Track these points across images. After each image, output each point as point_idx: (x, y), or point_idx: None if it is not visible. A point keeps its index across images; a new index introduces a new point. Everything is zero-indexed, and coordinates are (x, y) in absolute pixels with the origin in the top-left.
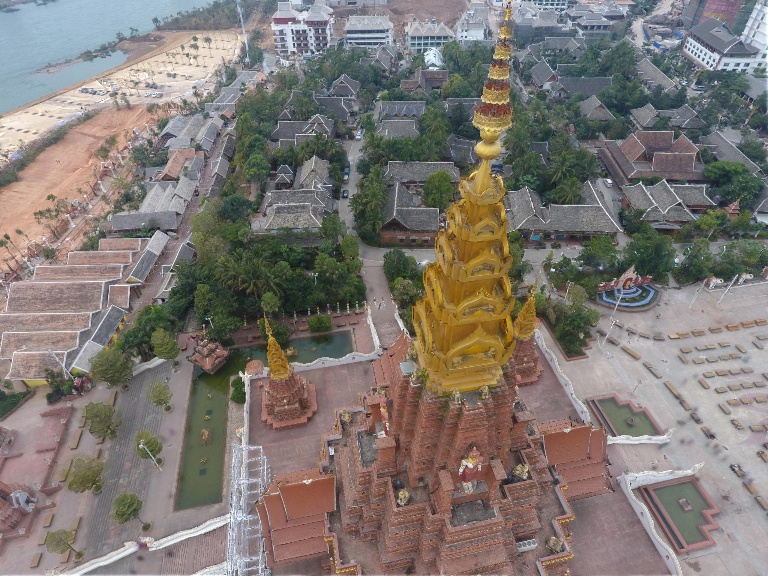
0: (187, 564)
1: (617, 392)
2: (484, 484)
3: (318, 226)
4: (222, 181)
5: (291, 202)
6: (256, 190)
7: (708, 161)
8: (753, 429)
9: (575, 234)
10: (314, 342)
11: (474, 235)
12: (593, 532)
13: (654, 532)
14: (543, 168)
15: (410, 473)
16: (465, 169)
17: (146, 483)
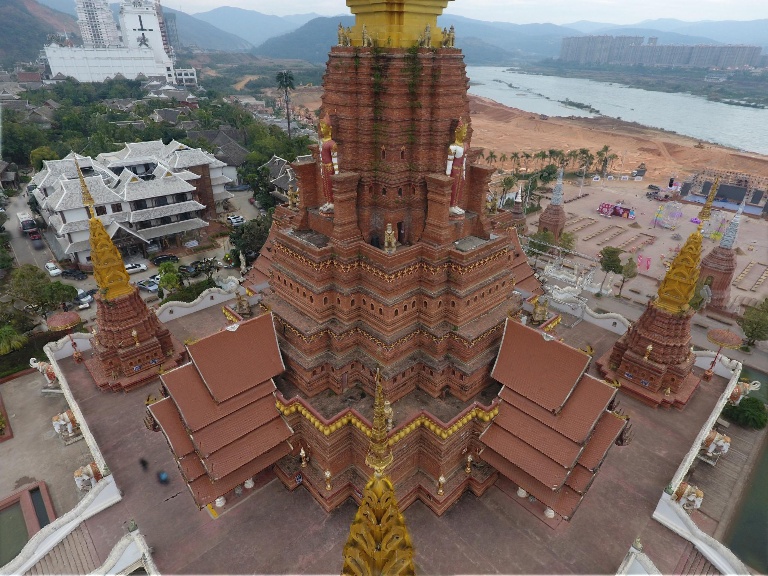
0: None
1: None
2: None
3: None
4: None
5: None
6: None
7: None
8: None
9: None
10: None
11: None
12: None
13: None
14: None
15: None
16: None
17: None
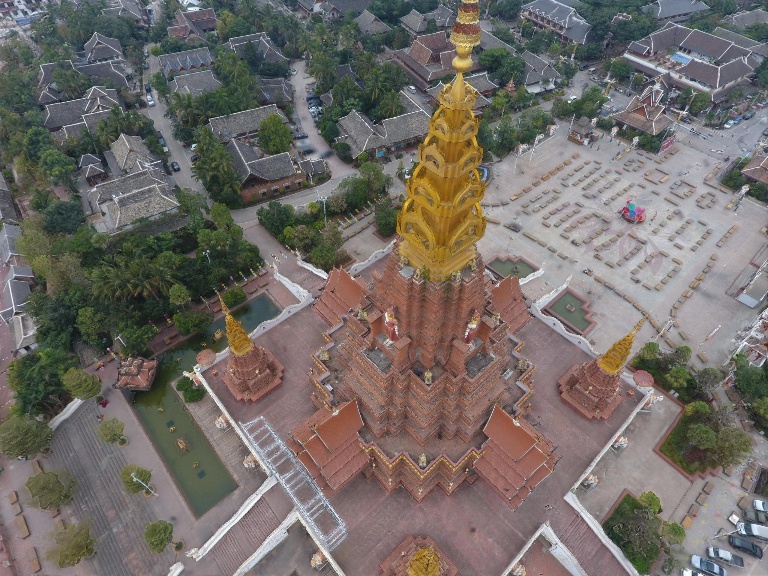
0: (244, 547)
1: (497, 253)
2: (478, 340)
3: (176, 206)
4: (7, 196)
5: (133, 190)
6: (66, 192)
7: (477, 52)
8: (586, 242)
9: (410, 141)
10: (235, 317)
11: (463, 136)
12: (531, 351)
13: (566, 331)
14: (357, 89)
15: (425, 358)
16: (286, 108)
17: (149, 514)
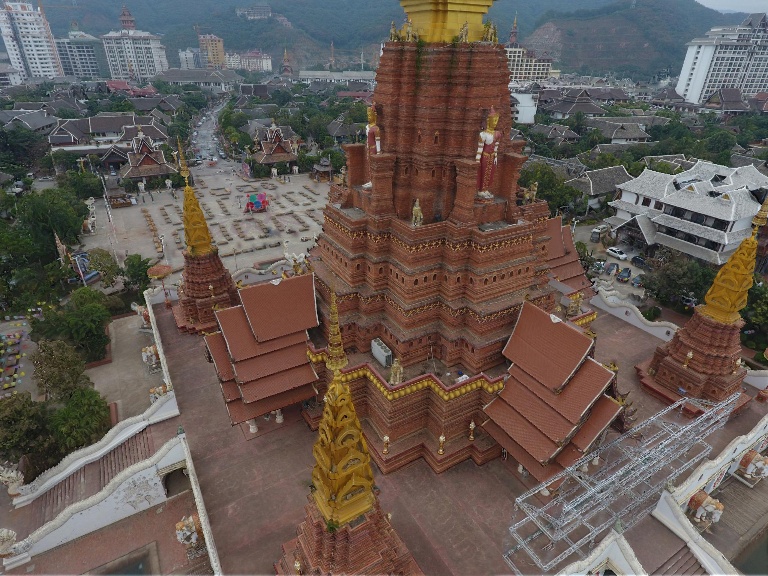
0: None
1: None
2: None
3: None
4: None
5: None
6: None
7: None
8: (268, 231)
9: None
10: None
11: None
12: None
13: None
14: None
15: None
16: None
17: None
